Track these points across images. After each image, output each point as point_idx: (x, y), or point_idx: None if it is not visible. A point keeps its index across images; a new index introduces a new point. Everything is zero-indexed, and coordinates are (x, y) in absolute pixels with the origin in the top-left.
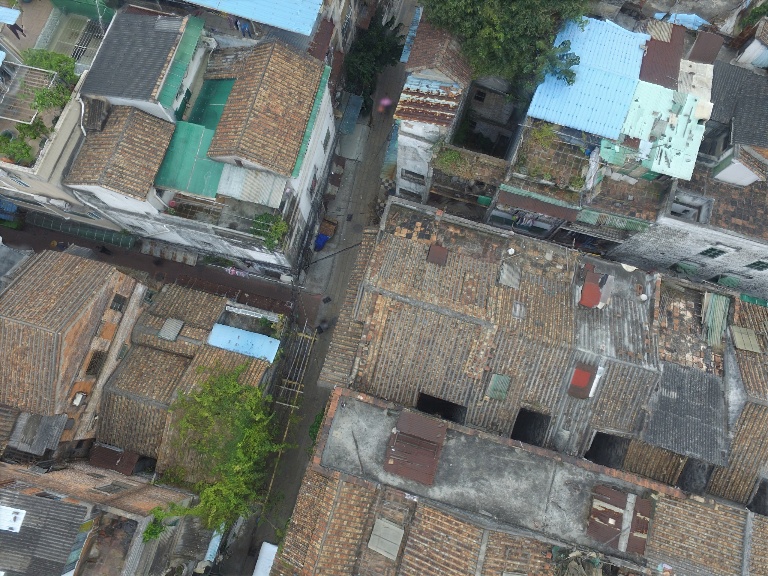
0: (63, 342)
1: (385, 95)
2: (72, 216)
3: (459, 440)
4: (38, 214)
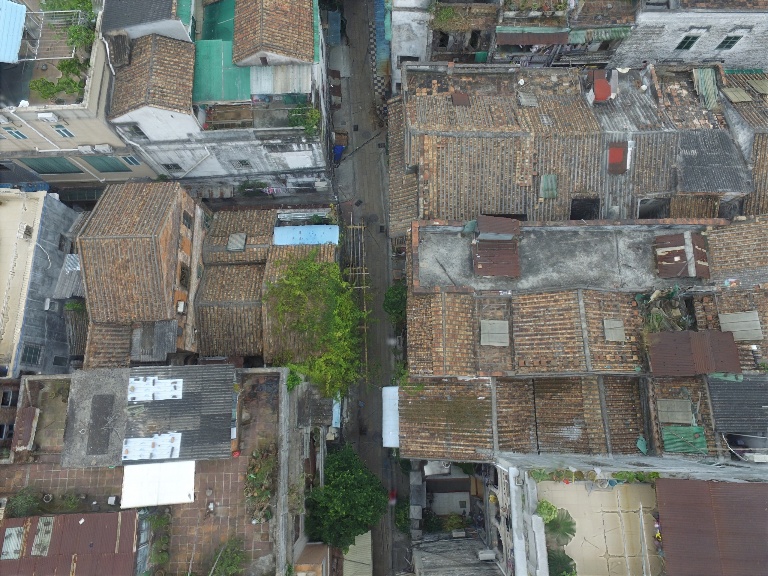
0: (159, 245)
1: (353, 15)
2: (107, 176)
3: (530, 238)
4: (70, 189)
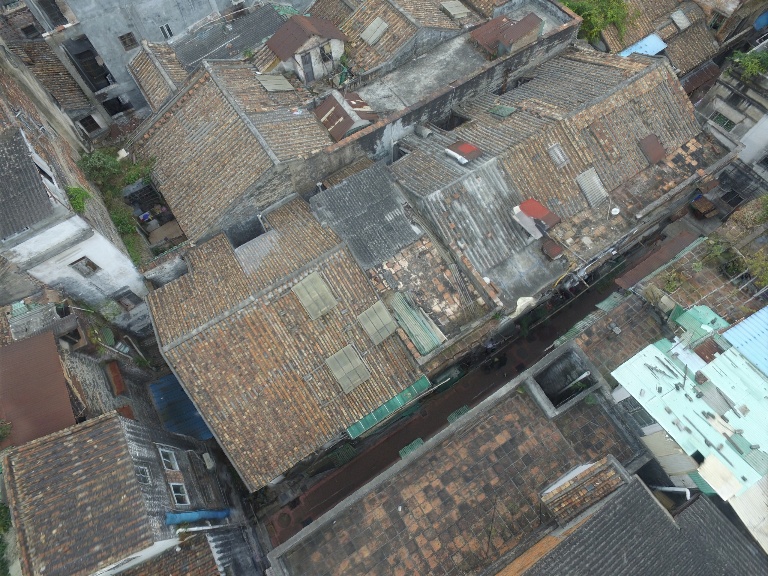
0: None
1: None
2: None
3: None
4: None
